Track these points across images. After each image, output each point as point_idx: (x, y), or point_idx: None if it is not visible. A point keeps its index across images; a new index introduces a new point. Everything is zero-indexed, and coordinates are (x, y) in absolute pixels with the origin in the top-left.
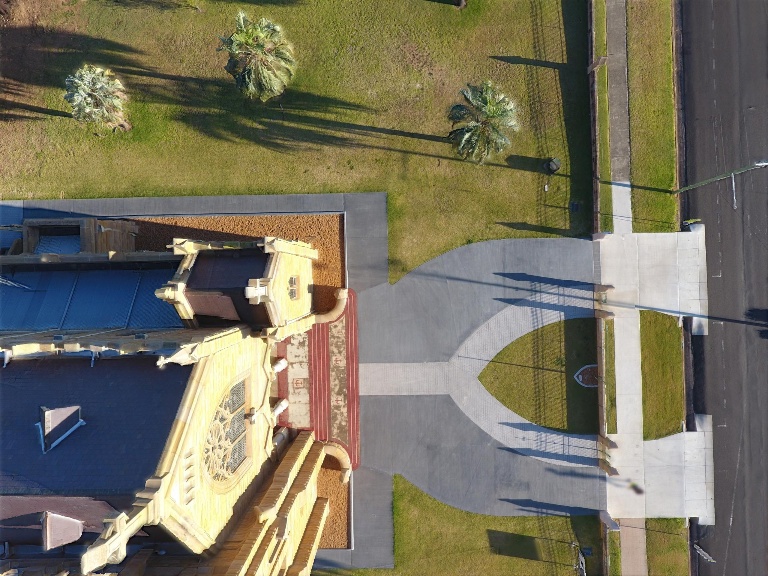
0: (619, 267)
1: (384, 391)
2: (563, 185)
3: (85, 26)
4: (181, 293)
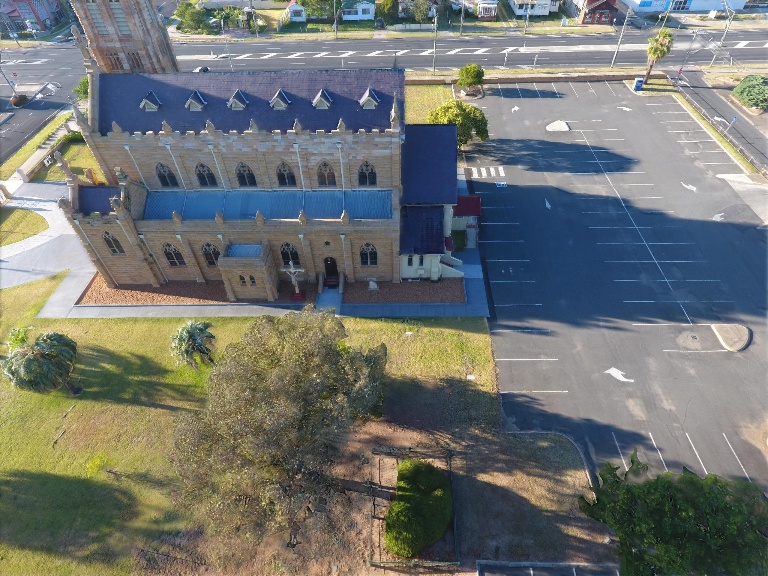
0: None
1: None
2: None
3: None
4: None
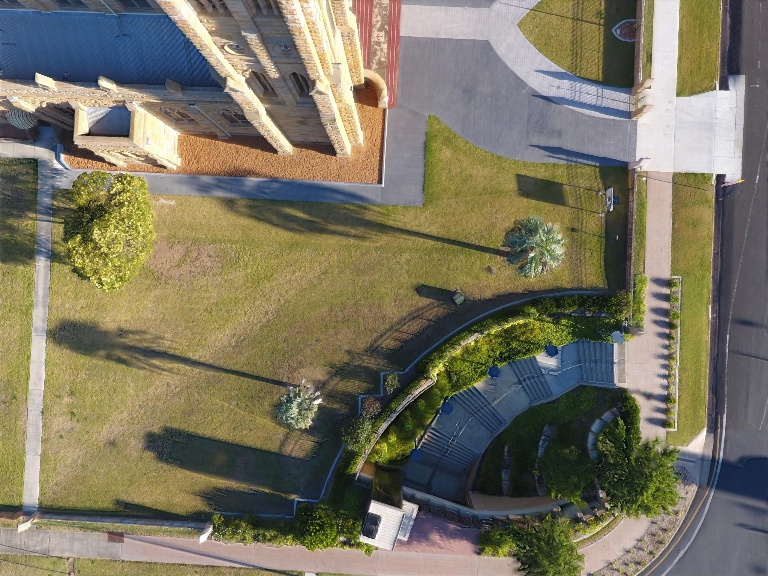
0: None
1: (424, 33)
2: None
3: None
4: None
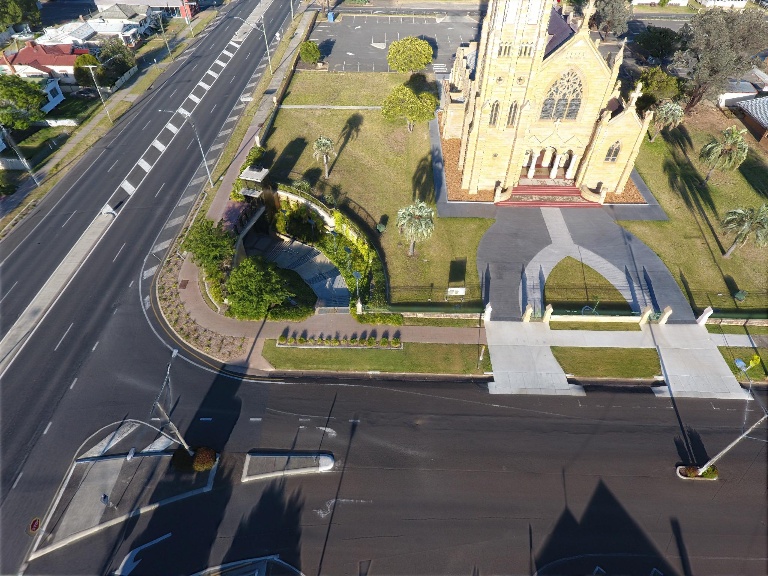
0: (684, 336)
1: (546, 217)
2: (729, 304)
3: (693, 133)
4: (615, 95)
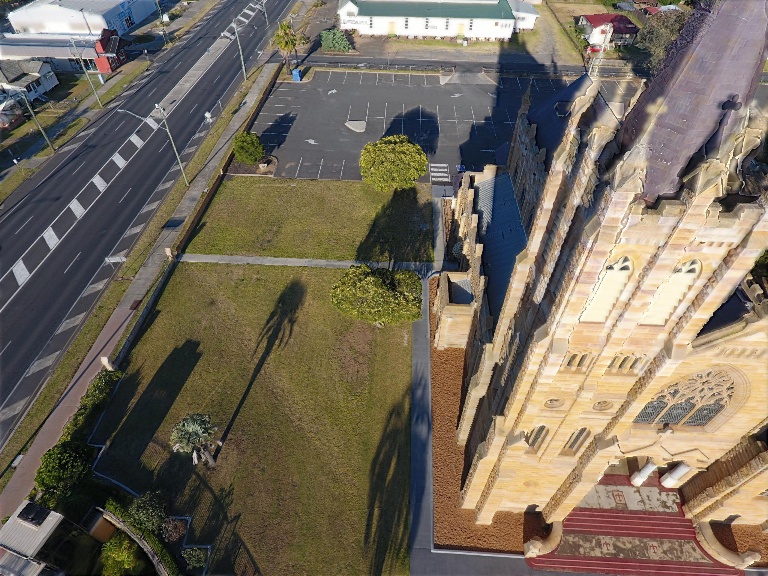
0: None
1: None
2: None
3: None
4: None
